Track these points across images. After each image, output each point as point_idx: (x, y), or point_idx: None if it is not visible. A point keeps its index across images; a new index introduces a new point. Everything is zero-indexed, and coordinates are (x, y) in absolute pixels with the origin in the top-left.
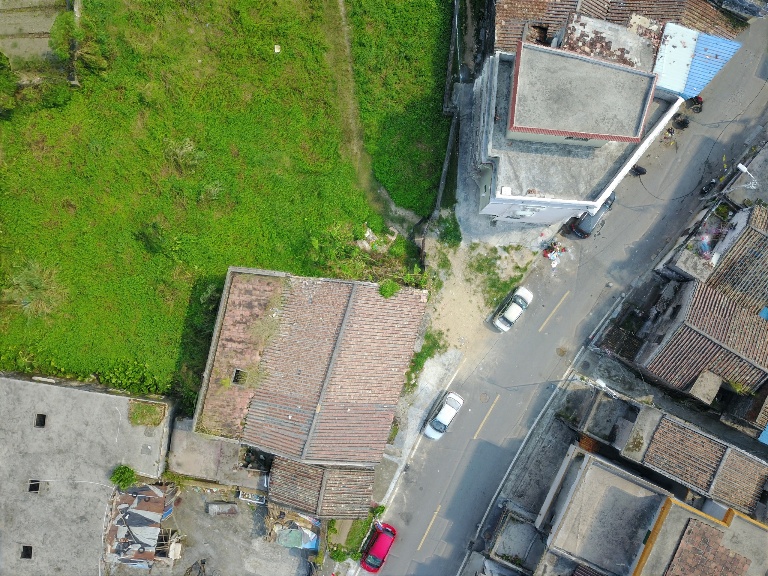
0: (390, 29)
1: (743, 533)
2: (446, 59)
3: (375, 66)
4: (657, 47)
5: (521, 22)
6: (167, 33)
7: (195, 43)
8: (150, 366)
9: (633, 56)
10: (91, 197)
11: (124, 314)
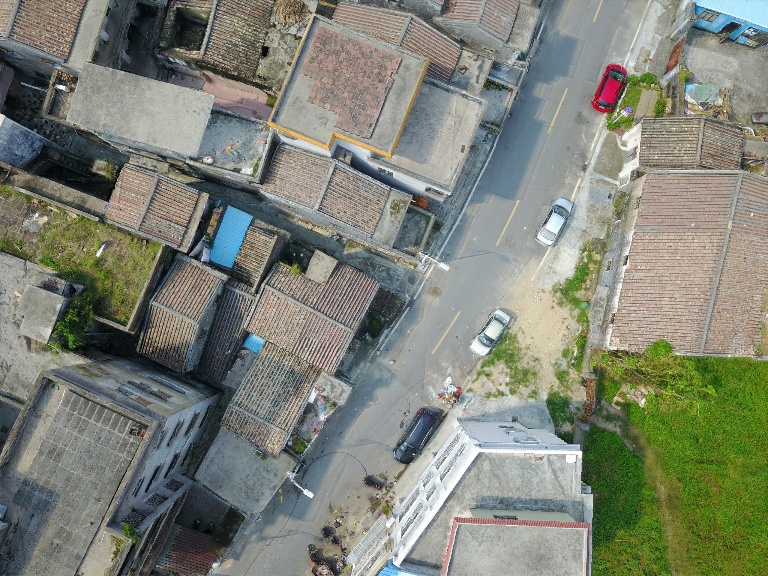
0: None
1: (316, 128)
2: None
3: None
4: None
5: None
6: None
7: None
8: None
9: None
10: None
11: None
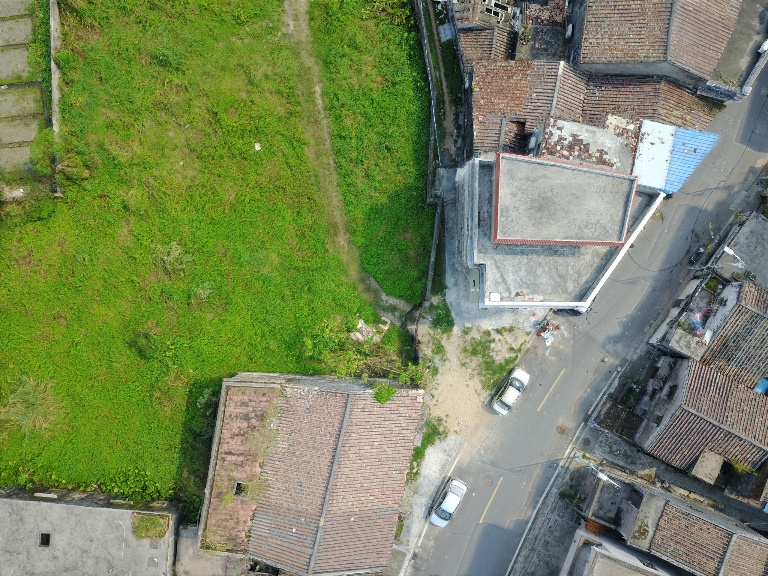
0: (369, 120)
1: None
2: (427, 146)
3: (356, 158)
4: (635, 146)
5: (498, 117)
6: (147, 138)
7: (175, 146)
8: (151, 473)
9: (612, 156)
10: (81, 307)
11: (122, 422)
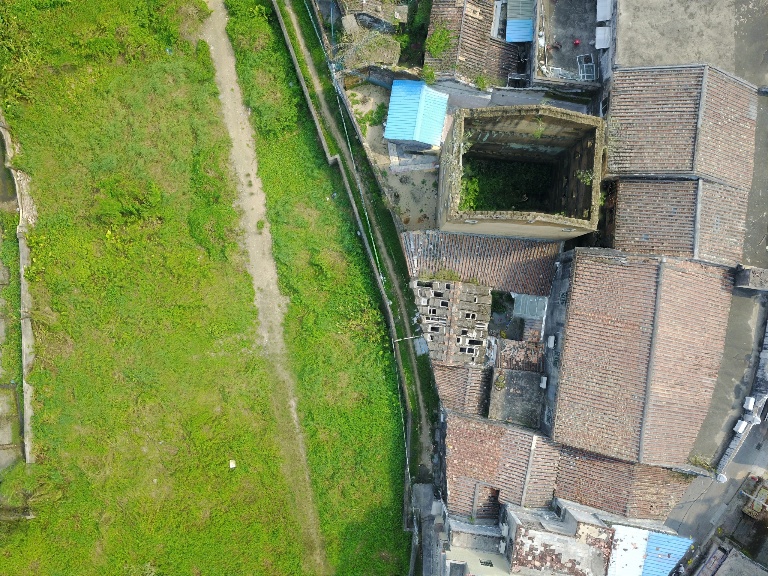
0: (344, 437)
1: None
2: (403, 465)
3: (332, 477)
4: (608, 557)
5: (472, 481)
6: (120, 454)
7: (149, 464)
8: None
9: (584, 567)
10: None
11: None
